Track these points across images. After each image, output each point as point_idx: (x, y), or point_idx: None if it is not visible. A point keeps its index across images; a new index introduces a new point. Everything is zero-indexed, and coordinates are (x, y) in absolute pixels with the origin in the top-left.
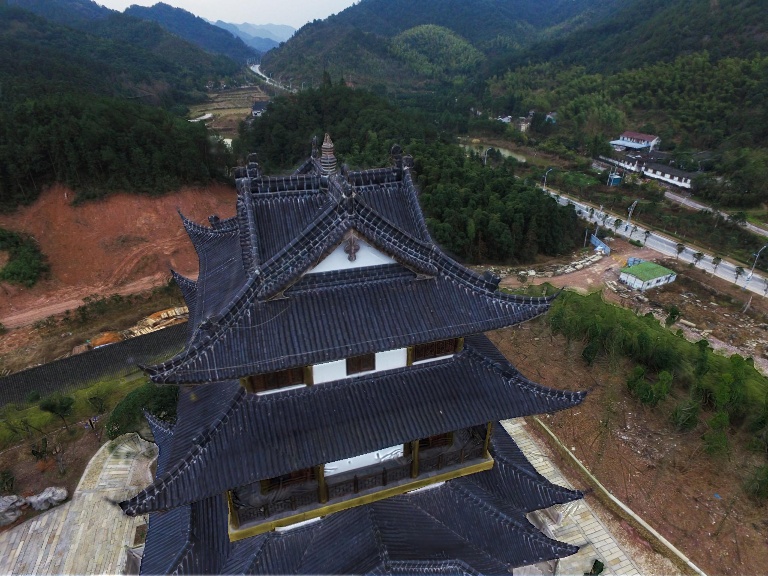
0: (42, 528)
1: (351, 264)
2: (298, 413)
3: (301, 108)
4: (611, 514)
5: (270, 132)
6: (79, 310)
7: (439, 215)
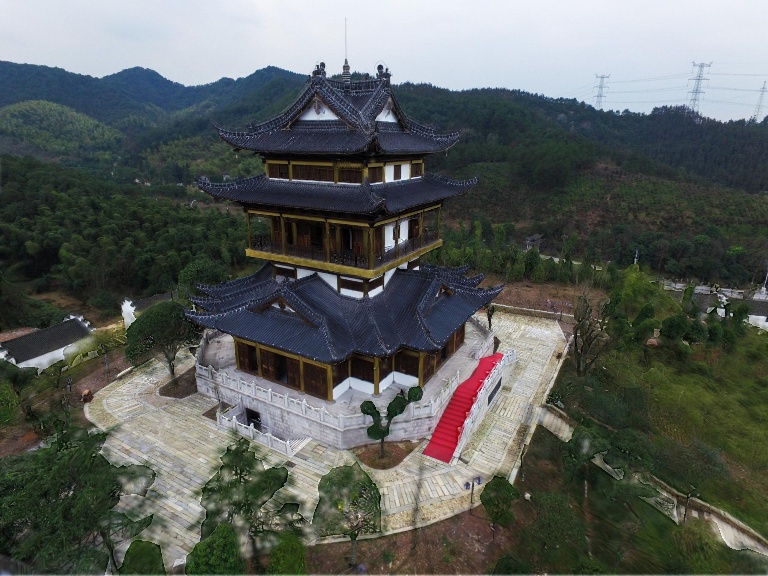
0: (105, 454)
1: (385, 119)
2: (389, 192)
3: None
4: None
5: None
6: None
7: None
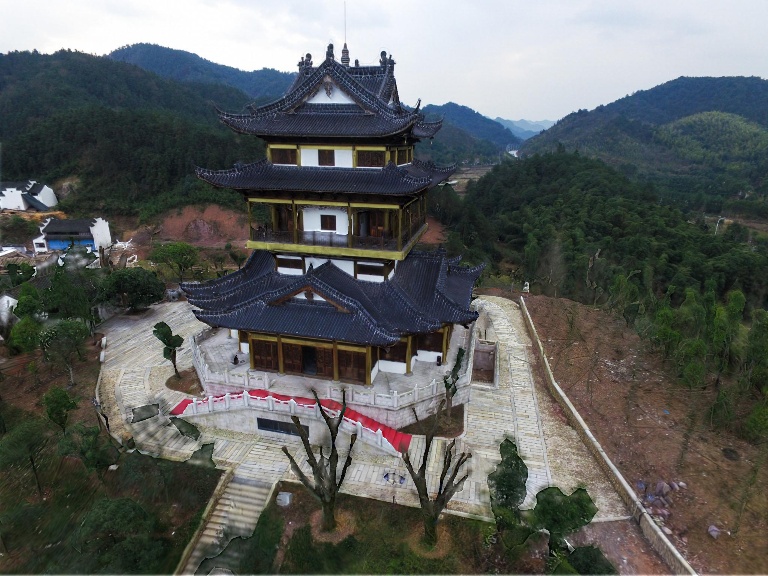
0: None
1: (331, 101)
2: (287, 174)
3: (523, 170)
4: (550, 398)
5: (490, 188)
6: None
7: (617, 261)
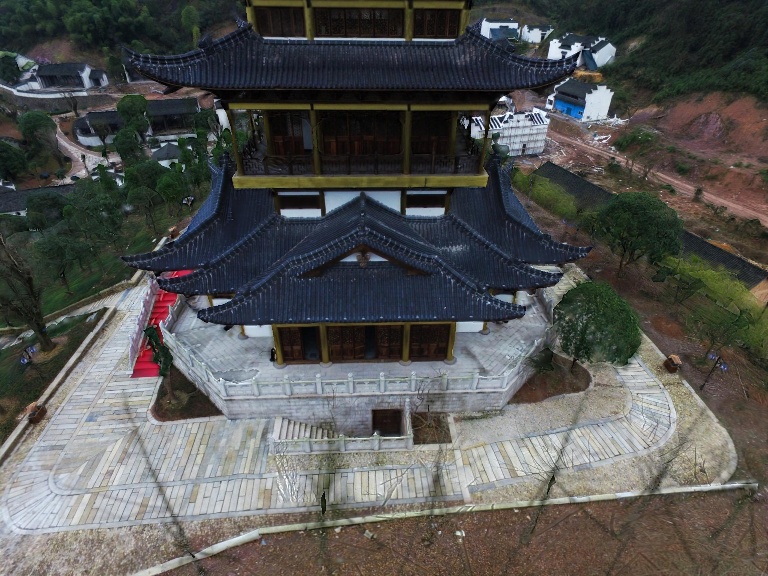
0: None
1: None
2: None
3: None
4: None
5: None
6: (752, 221)
7: None
